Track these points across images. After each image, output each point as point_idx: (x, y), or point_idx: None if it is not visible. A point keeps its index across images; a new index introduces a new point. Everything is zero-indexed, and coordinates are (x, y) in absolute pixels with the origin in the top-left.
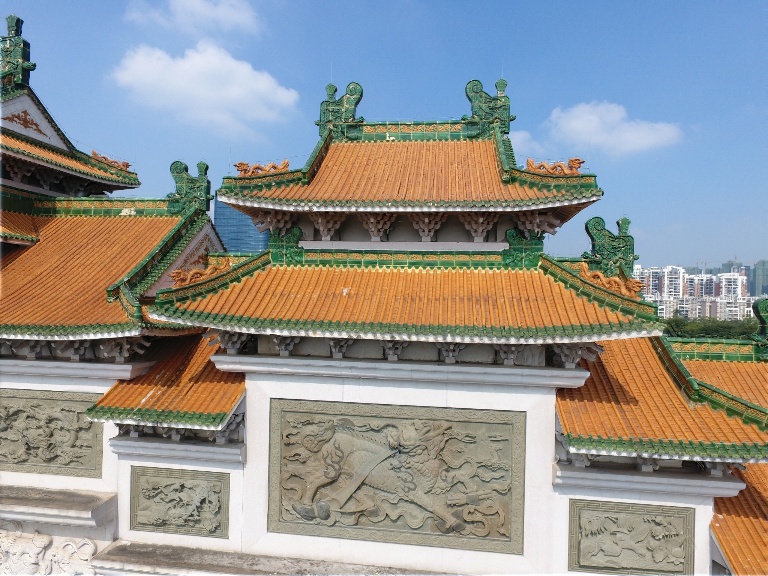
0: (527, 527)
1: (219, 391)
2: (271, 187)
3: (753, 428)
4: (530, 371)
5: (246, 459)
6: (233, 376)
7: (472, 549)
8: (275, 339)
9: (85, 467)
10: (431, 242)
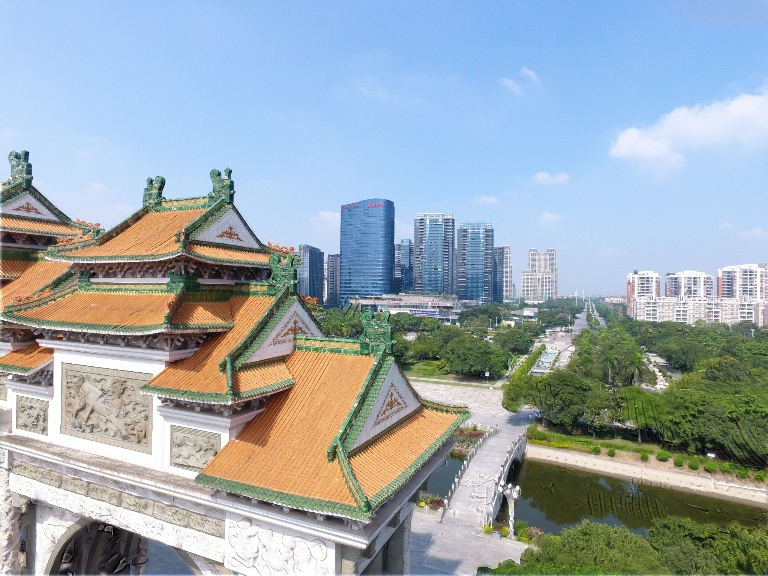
0: (153, 439)
1: None
2: (78, 249)
3: None
4: (146, 351)
5: (53, 394)
6: None
7: (133, 450)
8: (49, 331)
9: (3, 395)
10: (140, 278)
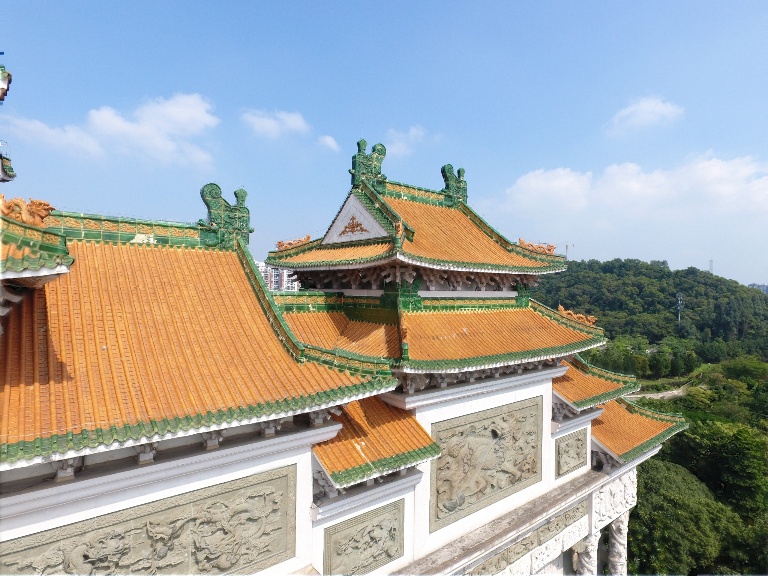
0: (543, 463)
1: (403, 428)
2: (402, 244)
3: (610, 382)
4: (552, 371)
5: None
6: (397, 413)
7: (524, 488)
8: None
9: (273, 554)
10: (486, 291)
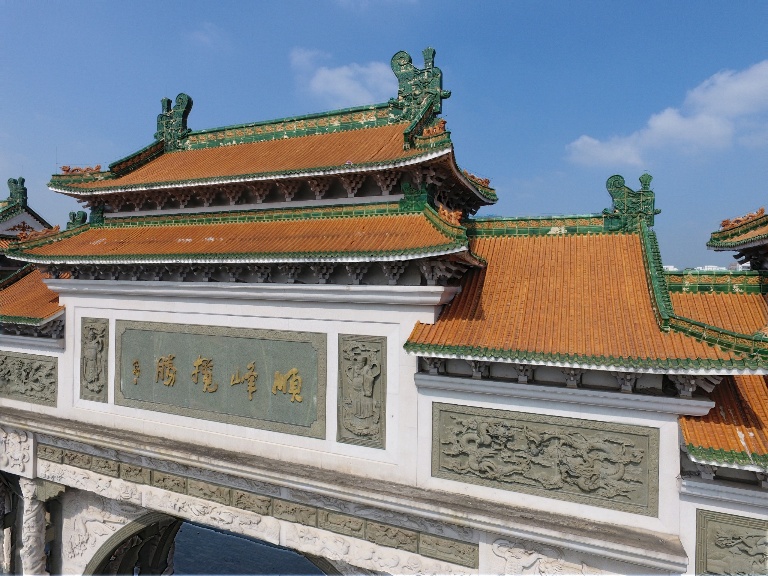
0: None
1: None
2: None
3: None
4: None
5: None
6: None
7: None
8: None
9: (633, 503)
10: None
